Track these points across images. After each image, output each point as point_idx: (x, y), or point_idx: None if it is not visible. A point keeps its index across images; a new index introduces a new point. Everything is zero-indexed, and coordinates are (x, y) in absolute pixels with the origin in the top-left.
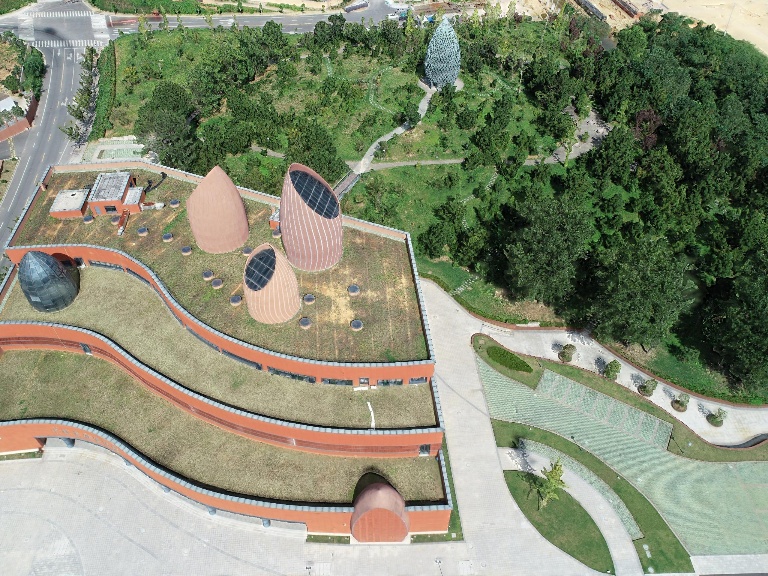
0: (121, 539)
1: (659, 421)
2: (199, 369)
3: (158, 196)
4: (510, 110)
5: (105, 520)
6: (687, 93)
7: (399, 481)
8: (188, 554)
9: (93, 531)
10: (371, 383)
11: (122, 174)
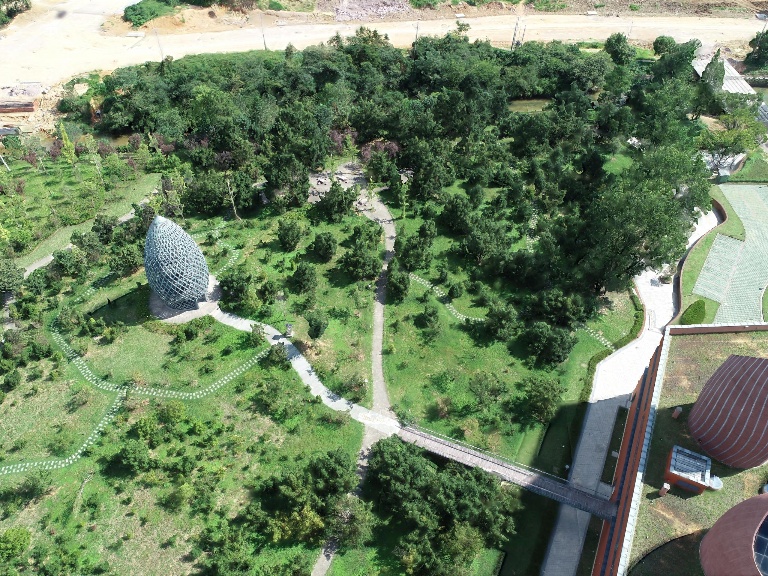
0: None
1: (718, 239)
2: None
3: None
4: None
5: None
6: None
7: None
8: None
9: None
10: None
11: None
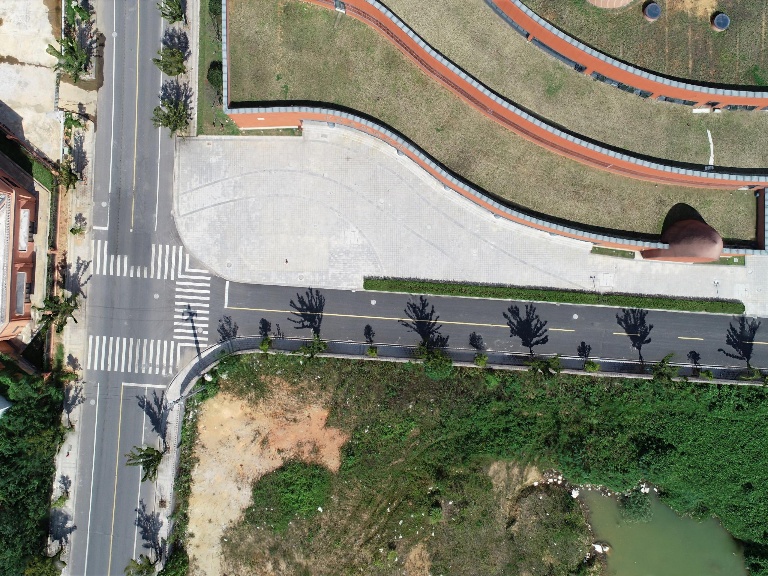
0: (409, 234)
1: None
2: (503, 63)
3: None
4: None
5: (389, 213)
6: None
7: (712, 216)
8: (477, 254)
9: (379, 223)
10: (717, 106)
11: None
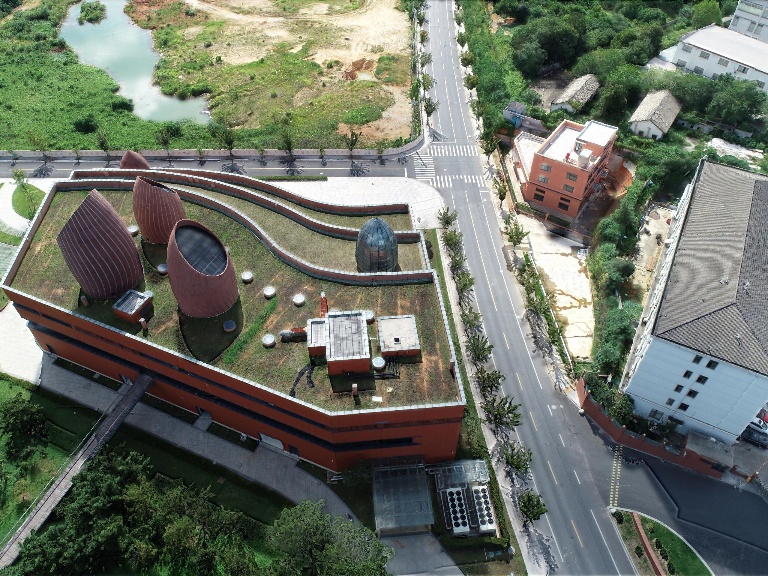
0: None
1: None
2: None
3: (294, 356)
4: None
5: None
6: None
7: None
8: None
9: None
10: None
11: (338, 358)
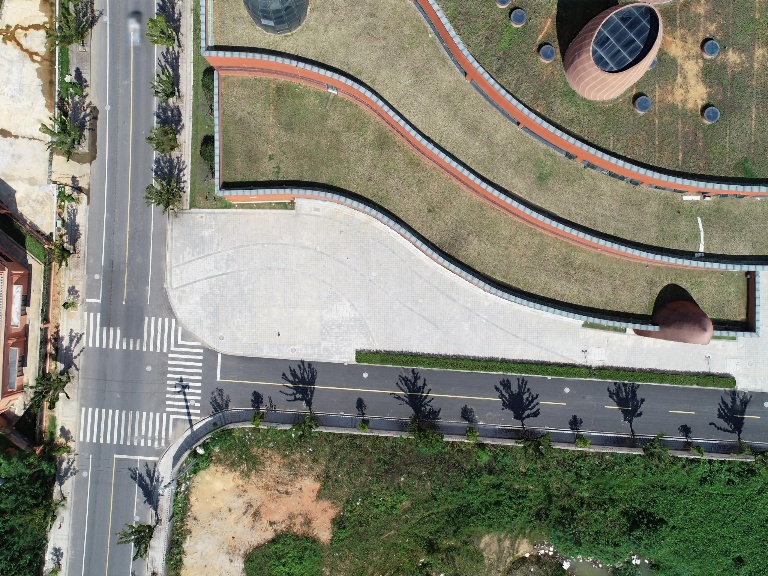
0: (401, 307)
1: None
2: (494, 150)
3: None
4: None
5: (381, 287)
6: None
7: (702, 296)
8: (469, 328)
9: (372, 297)
10: (708, 194)
11: None
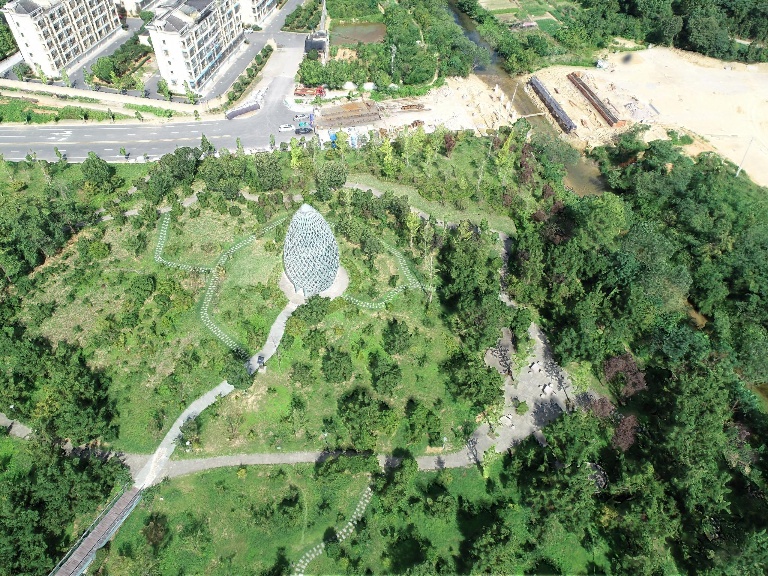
0: None
1: None
2: None
3: None
4: (407, 349)
5: None
6: (685, 298)
7: None
8: None
9: None
10: None
11: None
